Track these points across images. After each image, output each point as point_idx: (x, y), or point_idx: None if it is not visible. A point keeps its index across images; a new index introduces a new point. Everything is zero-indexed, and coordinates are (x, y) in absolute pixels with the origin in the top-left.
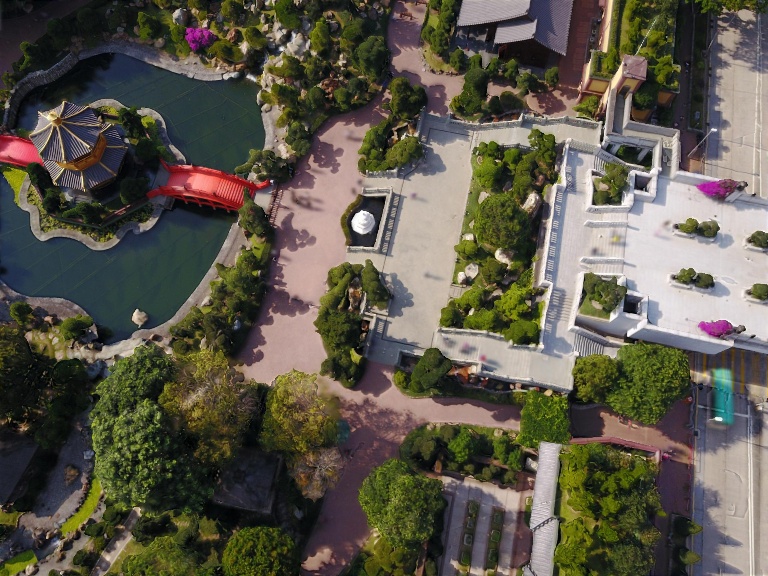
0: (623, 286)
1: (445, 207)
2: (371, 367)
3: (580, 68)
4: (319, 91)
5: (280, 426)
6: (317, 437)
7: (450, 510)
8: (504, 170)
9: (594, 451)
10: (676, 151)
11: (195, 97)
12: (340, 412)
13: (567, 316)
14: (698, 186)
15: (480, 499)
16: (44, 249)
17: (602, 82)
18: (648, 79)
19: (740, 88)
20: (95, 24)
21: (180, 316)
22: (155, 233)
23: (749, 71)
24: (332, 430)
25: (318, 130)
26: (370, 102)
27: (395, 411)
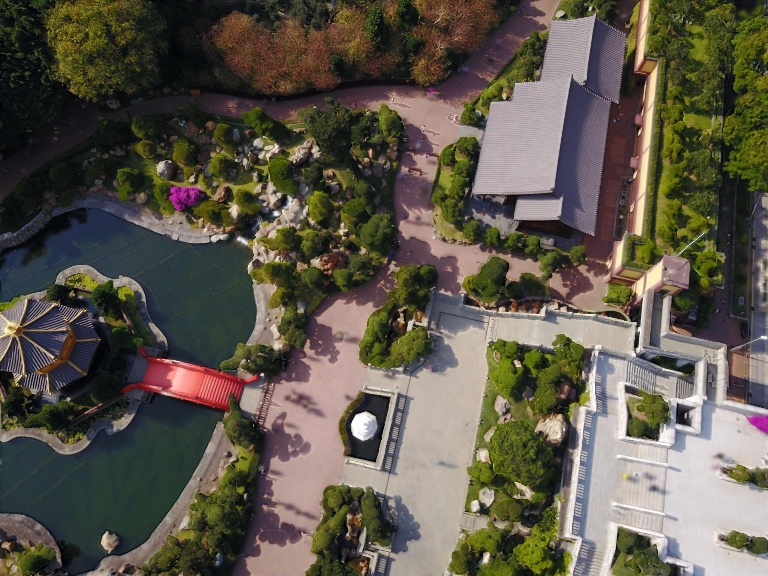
0: (666, 565)
1: (457, 412)
2: None
3: (609, 238)
4: (317, 275)
5: None
6: None
7: None
8: (524, 372)
9: None
10: (723, 373)
11: (179, 263)
12: None
13: (597, 571)
14: (749, 418)
15: None
16: (6, 450)
17: (636, 272)
18: (690, 281)
19: None
20: (70, 180)
21: (155, 540)
22: (130, 432)
23: None
24: None
25: (315, 310)
26: (374, 276)
27: None
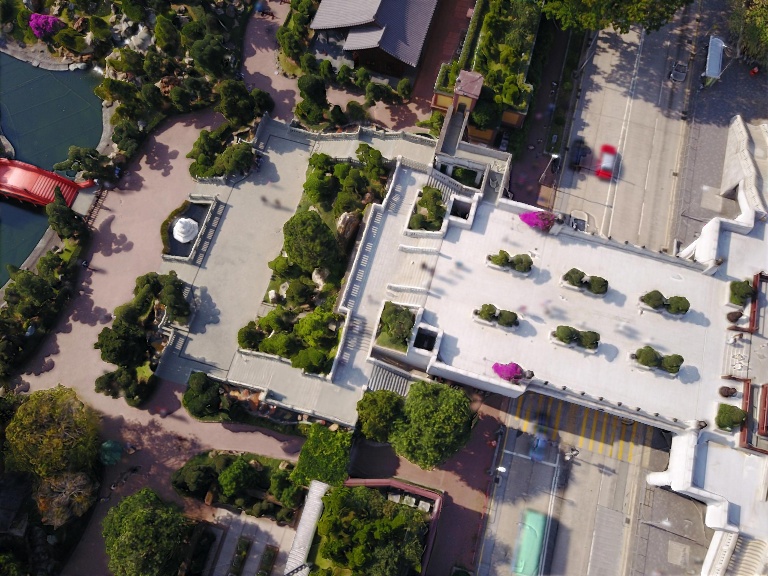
0: None
1: (271, 220)
2: (162, 385)
3: None
4: (151, 89)
5: (16, 447)
6: (59, 461)
7: (219, 545)
8: (336, 184)
9: (356, 496)
10: (503, 177)
11: (37, 87)
12: (121, 432)
13: (367, 346)
14: (520, 216)
15: (254, 536)
16: None
17: (447, 98)
18: (486, 98)
19: (608, 113)
20: None
21: None
22: None
23: (620, 95)
24: (85, 453)
25: (155, 129)
26: (215, 103)
27: (180, 434)
